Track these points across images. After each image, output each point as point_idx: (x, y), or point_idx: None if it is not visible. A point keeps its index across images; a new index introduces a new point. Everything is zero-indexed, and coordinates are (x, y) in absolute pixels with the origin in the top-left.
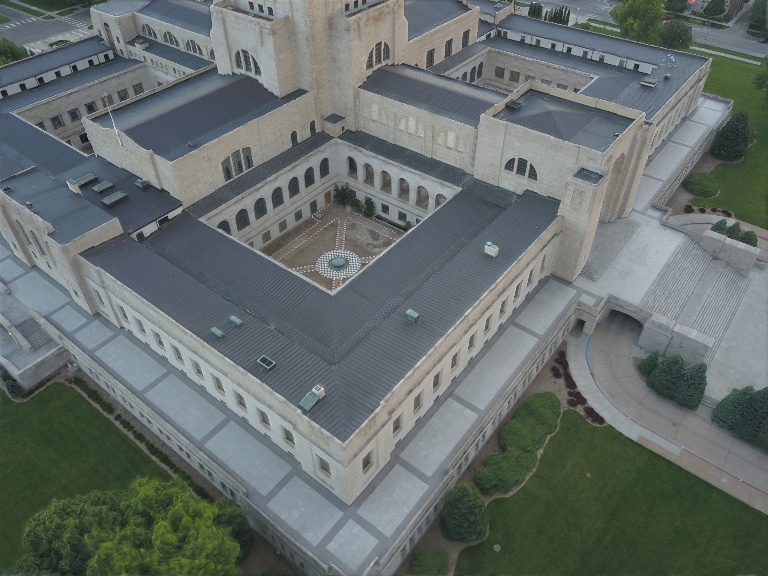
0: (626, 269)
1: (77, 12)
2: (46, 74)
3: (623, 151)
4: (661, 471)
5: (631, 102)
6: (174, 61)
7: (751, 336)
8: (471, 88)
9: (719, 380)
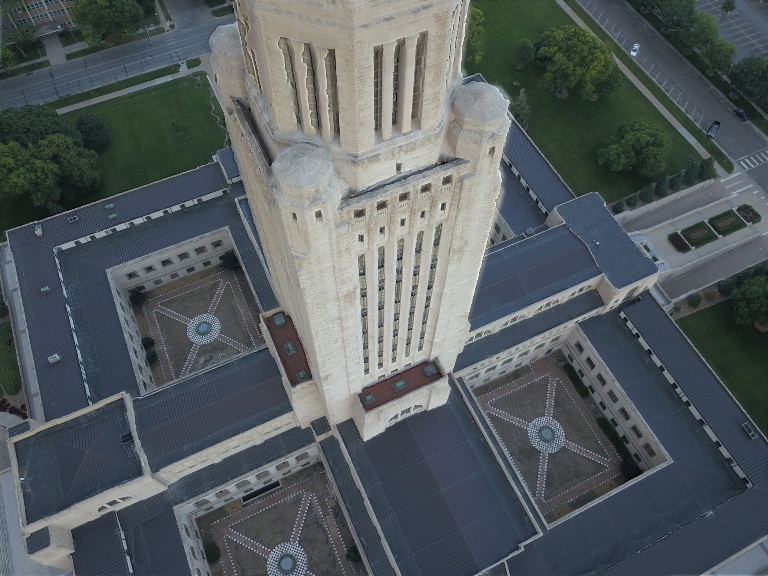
0: None
1: None
2: (514, 167)
3: None
4: None
5: None
6: None
7: None
8: (206, 442)
9: None
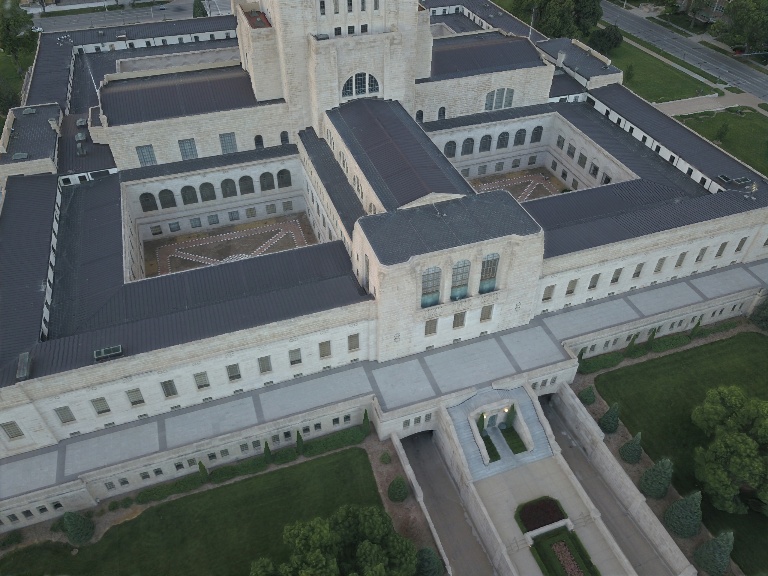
0: None
1: None
2: None
3: None
4: None
5: (161, 33)
6: None
7: None
8: None
9: None
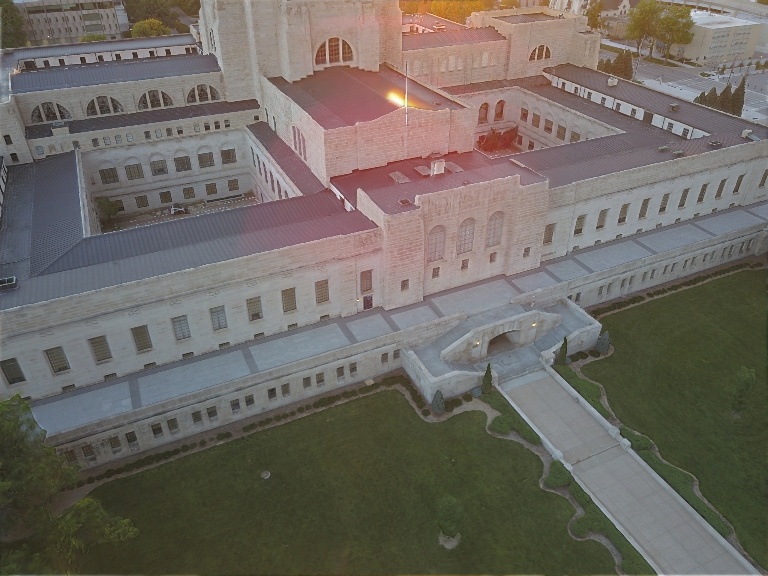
0: None
1: None
2: None
3: None
4: None
5: None
6: (141, 124)
7: None
8: None
9: None
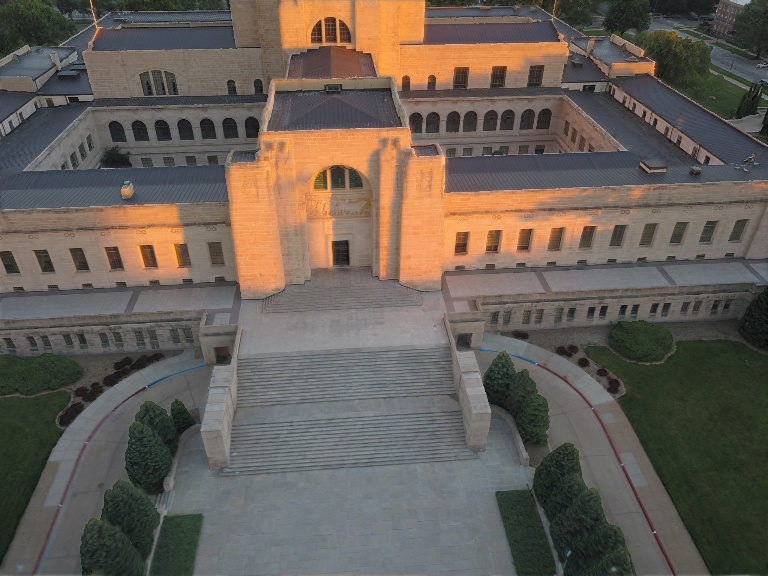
0: (311, 324)
1: None
2: None
3: (353, 165)
4: (6, 499)
5: (581, 174)
6: None
7: (338, 498)
8: None
9: (211, 495)
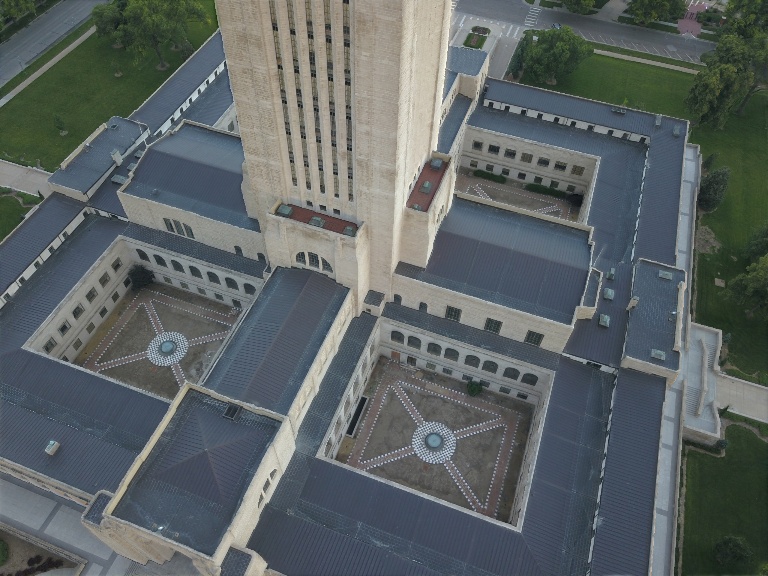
0: None
1: (555, 9)
2: None
3: None
4: None
5: None
6: None
7: None
8: (304, 365)
9: None
